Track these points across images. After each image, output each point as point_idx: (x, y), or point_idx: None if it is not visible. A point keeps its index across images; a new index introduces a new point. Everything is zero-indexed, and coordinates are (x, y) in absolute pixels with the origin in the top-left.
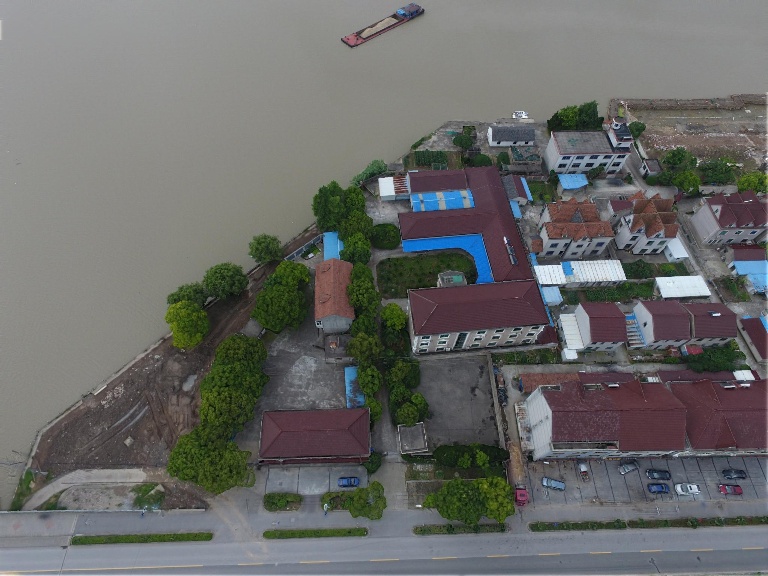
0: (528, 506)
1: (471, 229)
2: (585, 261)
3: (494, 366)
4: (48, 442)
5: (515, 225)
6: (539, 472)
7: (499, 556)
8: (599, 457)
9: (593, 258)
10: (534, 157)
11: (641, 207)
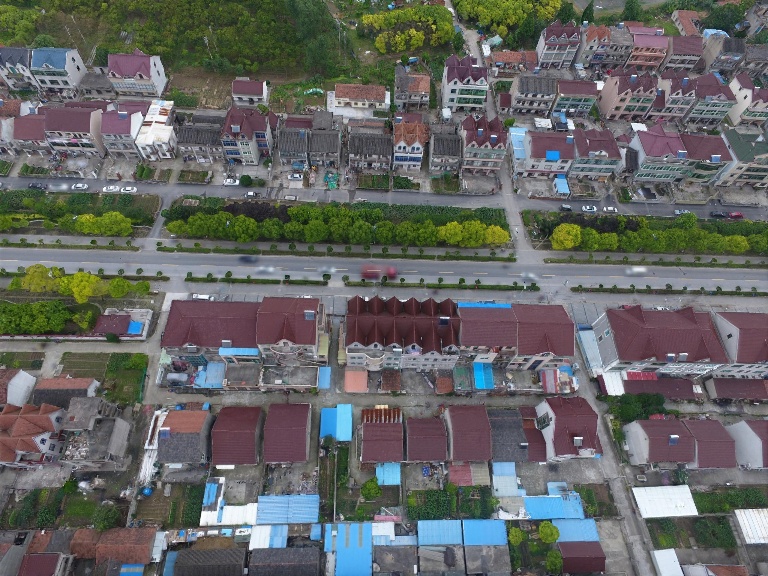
0: None
1: None
2: None
3: None
4: None
5: None
6: None
7: None
8: None
9: (763, 559)
10: None
11: None
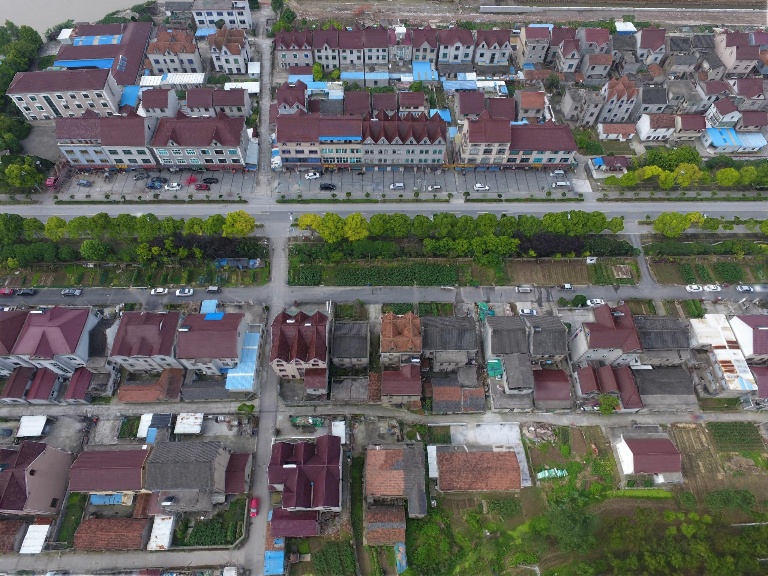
0: (61, 194)
1: (107, 55)
2: (179, 73)
3: None
4: None
5: (142, 54)
6: (80, 179)
7: (26, 215)
8: (112, 164)
9: None
10: (186, 18)
11: (222, 36)
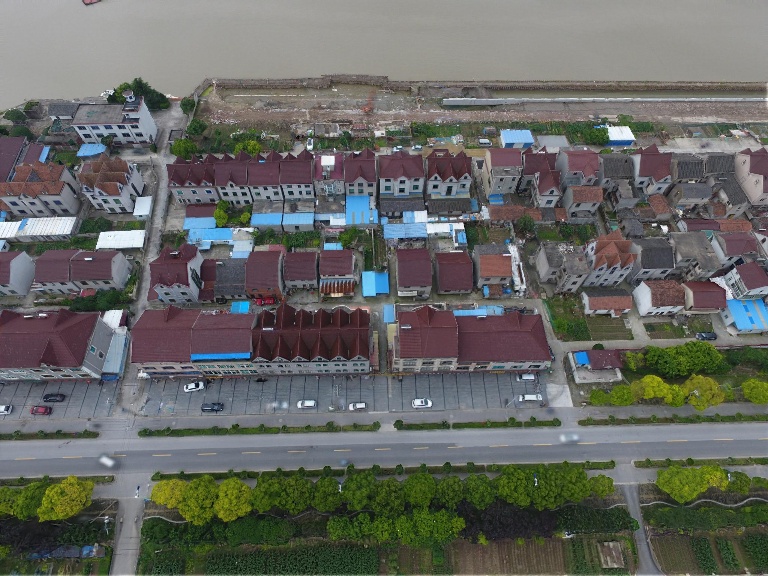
0: None
1: None
2: (43, 218)
3: None
4: None
5: None
6: None
7: None
8: None
9: None
10: (71, 129)
11: (99, 169)
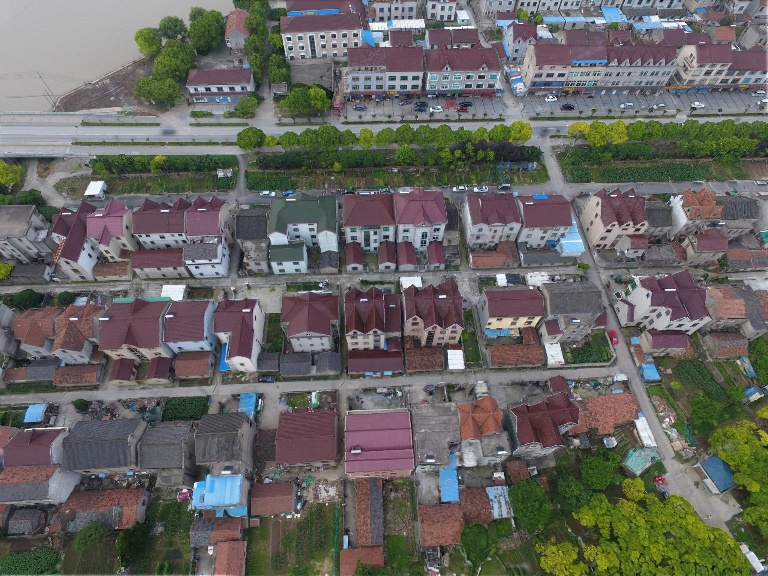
0: (343, 117)
1: (332, 6)
2: (401, 20)
3: (335, 66)
4: (64, 101)
5: (361, 5)
6: (353, 105)
7: None
8: (384, 91)
9: None
10: None
11: None
